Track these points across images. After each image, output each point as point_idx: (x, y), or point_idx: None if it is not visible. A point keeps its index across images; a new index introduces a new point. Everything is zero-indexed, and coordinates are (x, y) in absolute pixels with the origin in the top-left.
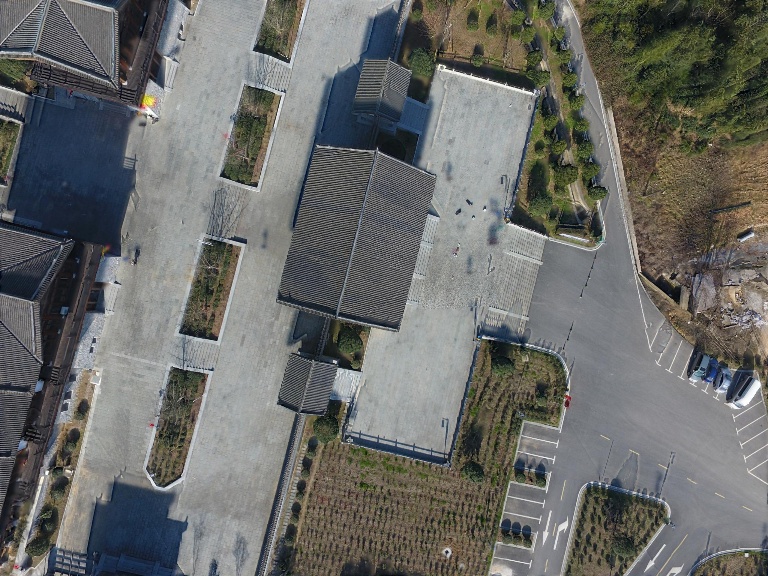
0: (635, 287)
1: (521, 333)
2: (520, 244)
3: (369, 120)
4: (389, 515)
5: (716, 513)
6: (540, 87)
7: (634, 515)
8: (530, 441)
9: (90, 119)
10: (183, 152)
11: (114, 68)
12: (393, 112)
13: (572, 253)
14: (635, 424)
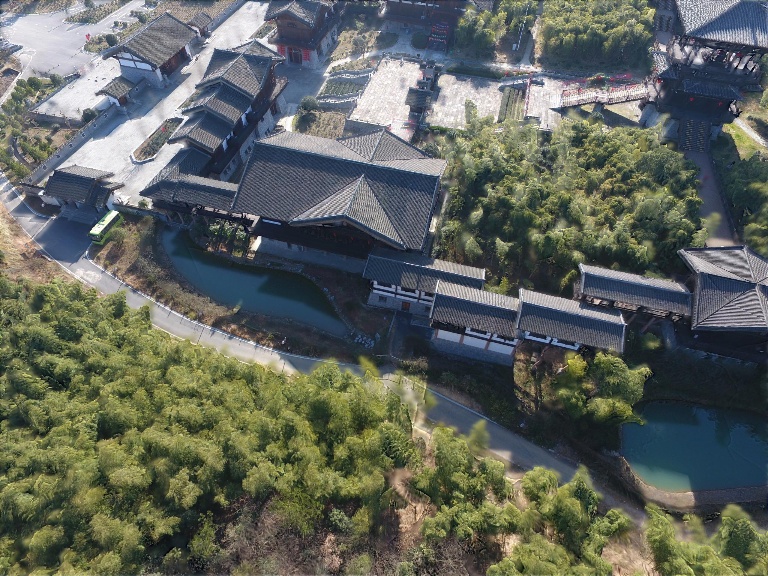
0: None
1: None
2: None
3: None
4: None
5: None
6: None
7: None
8: (115, 33)
9: None
10: None
11: None
12: None
13: None
14: None
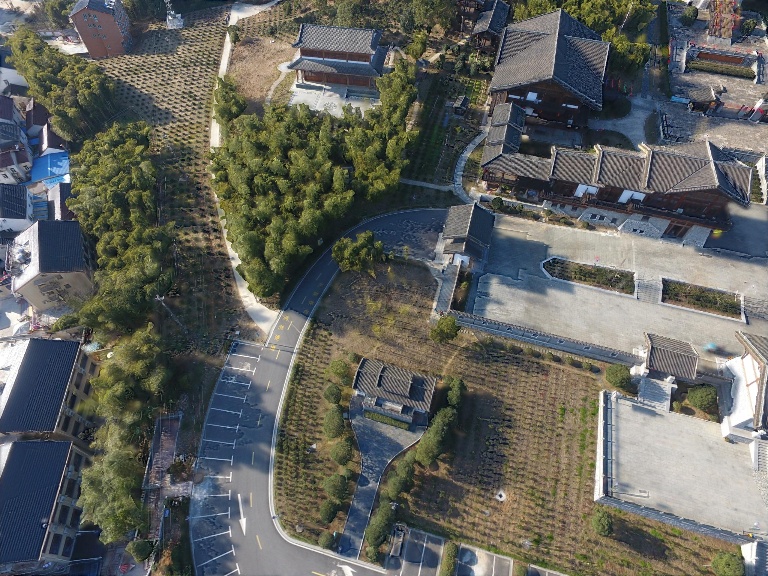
0: None
1: None
2: None
3: None
4: (537, 434)
5: None
6: None
7: None
8: None
9: None
10: None
11: None
12: None
13: None
14: None
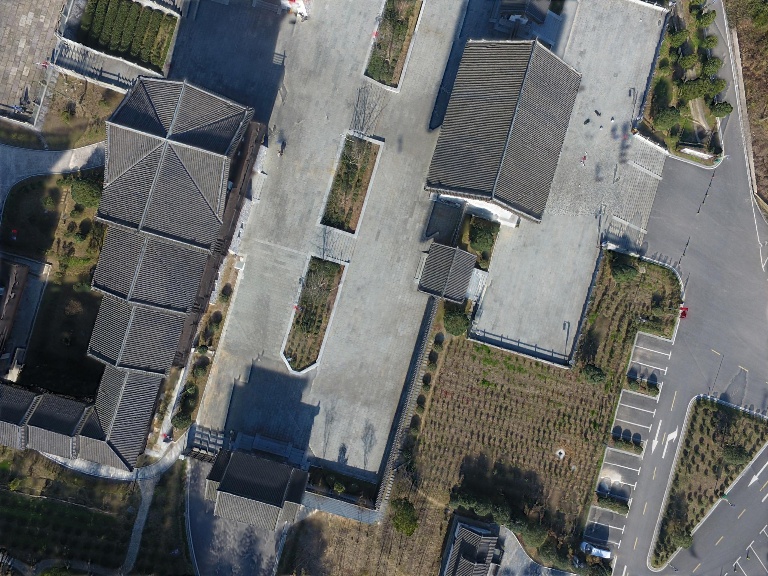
0: (751, 207)
1: (639, 246)
2: (643, 157)
3: (506, 27)
4: (508, 413)
5: None
6: (672, 2)
7: (741, 429)
8: (643, 351)
9: (243, 15)
10: (330, 50)
11: None
12: (539, 14)
13: (691, 170)
14: (745, 341)
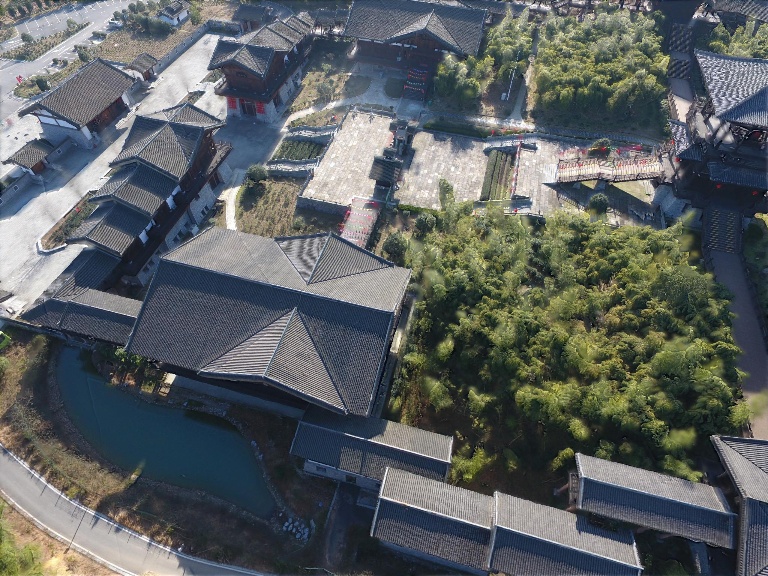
0: None
1: None
2: None
3: None
4: None
5: None
6: None
7: None
8: (52, 73)
9: None
10: None
11: (157, 112)
12: None
13: None
14: None
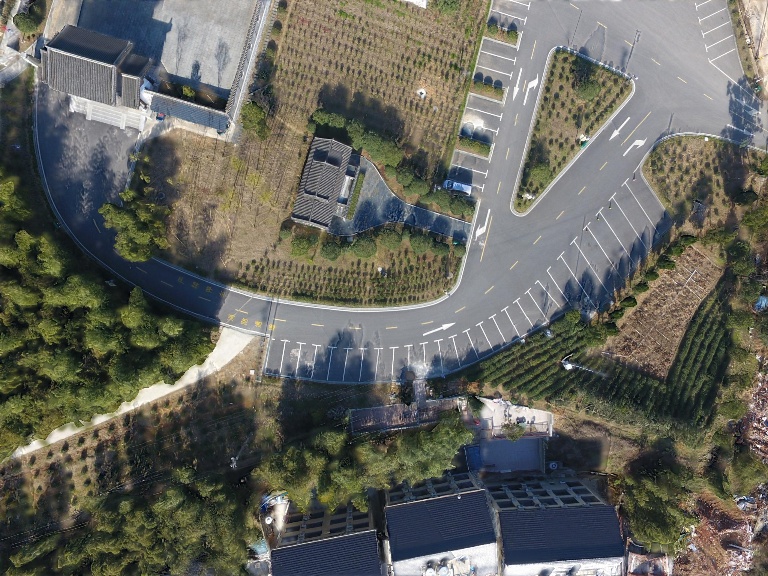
0: None
1: None
2: None
3: None
4: (367, 46)
5: (678, 97)
6: None
7: (600, 82)
8: (503, 1)
9: None
10: None
11: None
12: None
13: None
14: None
